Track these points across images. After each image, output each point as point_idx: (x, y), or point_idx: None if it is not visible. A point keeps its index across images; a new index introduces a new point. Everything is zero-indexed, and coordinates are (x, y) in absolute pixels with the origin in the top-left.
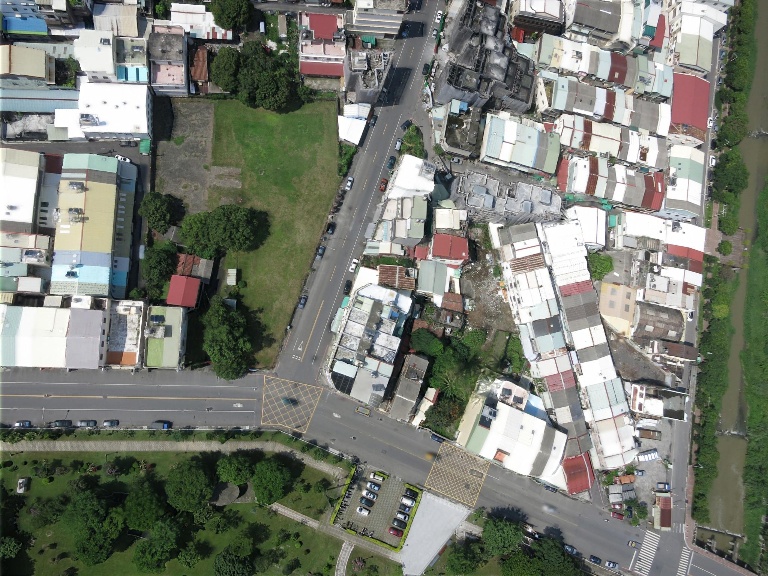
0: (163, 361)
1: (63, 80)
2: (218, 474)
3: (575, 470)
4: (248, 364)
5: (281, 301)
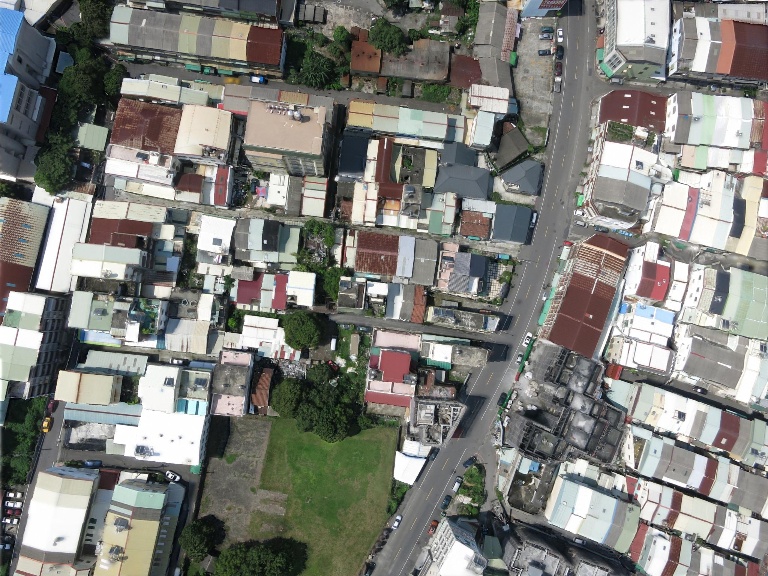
0: None
1: (128, 395)
2: None
3: None
4: None
5: None
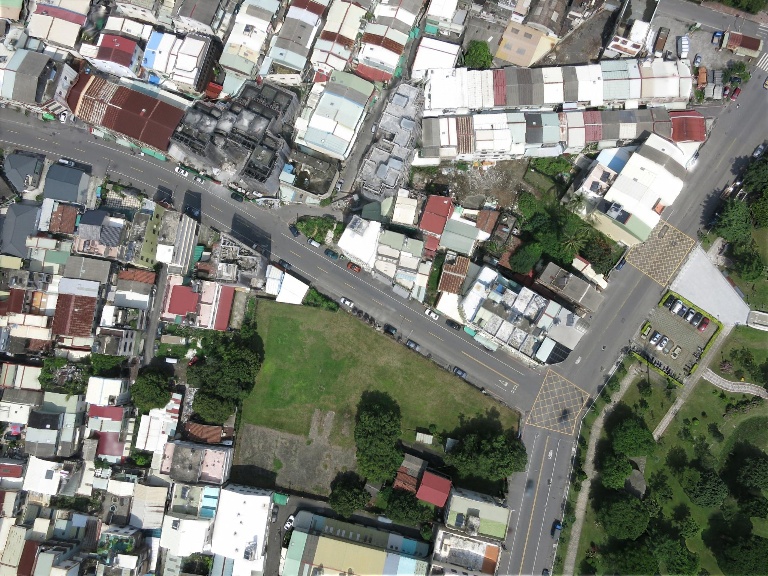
0: (501, 522)
1: (203, 567)
2: (617, 488)
3: (683, 130)
4: (513, 438)
5: (455, 394)
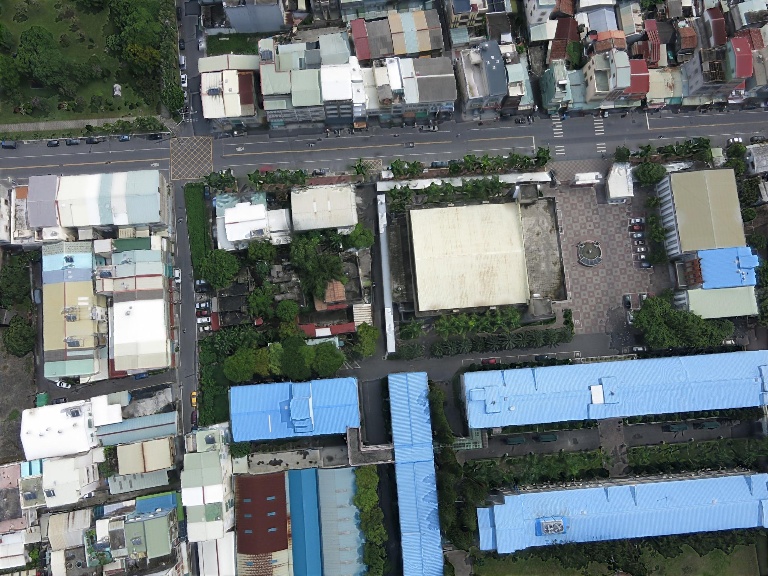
0: None
1: None
2: None
3: None
4: None
5: None
